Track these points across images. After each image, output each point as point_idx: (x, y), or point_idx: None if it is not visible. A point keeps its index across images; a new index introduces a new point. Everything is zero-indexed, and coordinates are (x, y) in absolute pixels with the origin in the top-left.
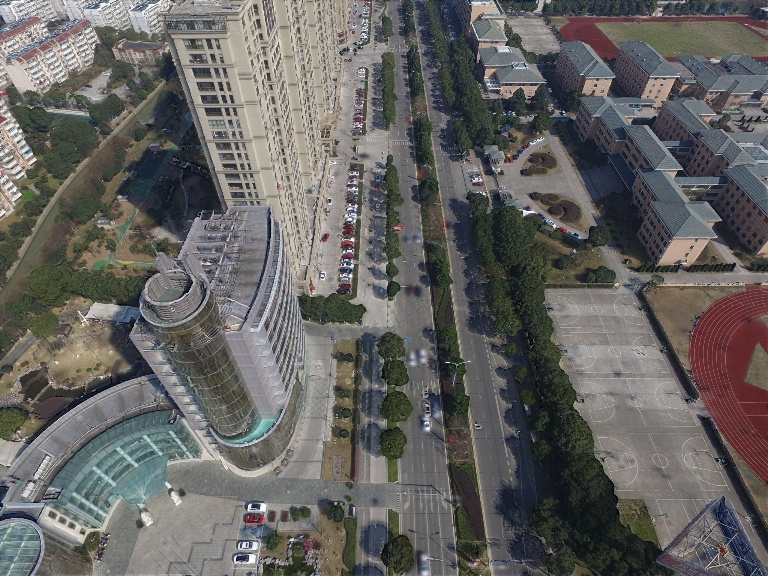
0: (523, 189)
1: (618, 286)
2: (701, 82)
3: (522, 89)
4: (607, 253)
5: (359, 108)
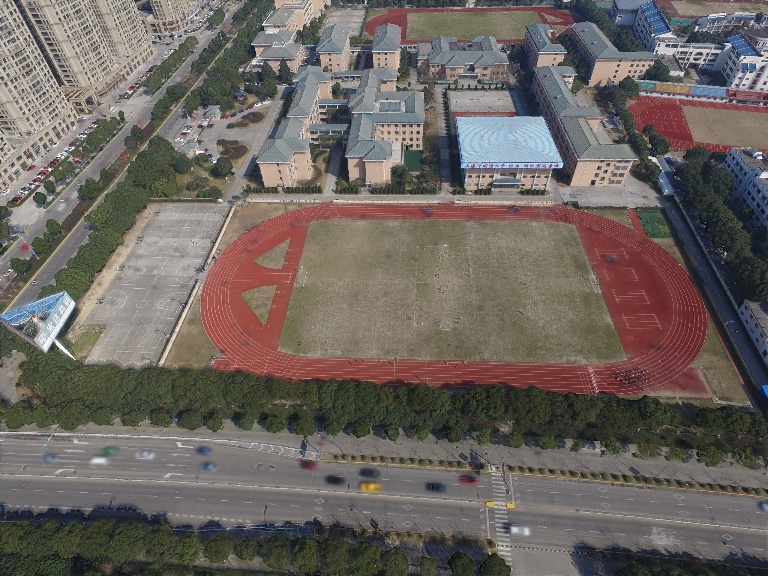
0: (217, 137)
1: (222, 201)
2: (429, 57)
3: (266, 62)
4: (237, 180)
5: (141, 80)
